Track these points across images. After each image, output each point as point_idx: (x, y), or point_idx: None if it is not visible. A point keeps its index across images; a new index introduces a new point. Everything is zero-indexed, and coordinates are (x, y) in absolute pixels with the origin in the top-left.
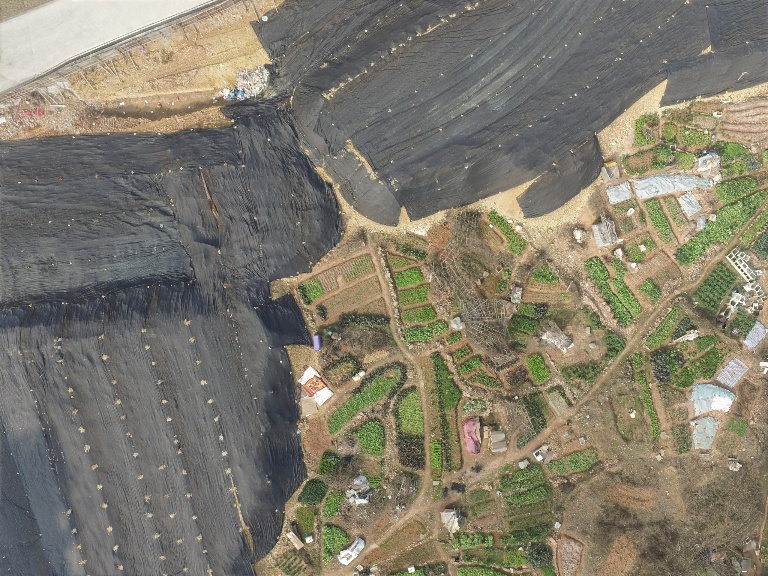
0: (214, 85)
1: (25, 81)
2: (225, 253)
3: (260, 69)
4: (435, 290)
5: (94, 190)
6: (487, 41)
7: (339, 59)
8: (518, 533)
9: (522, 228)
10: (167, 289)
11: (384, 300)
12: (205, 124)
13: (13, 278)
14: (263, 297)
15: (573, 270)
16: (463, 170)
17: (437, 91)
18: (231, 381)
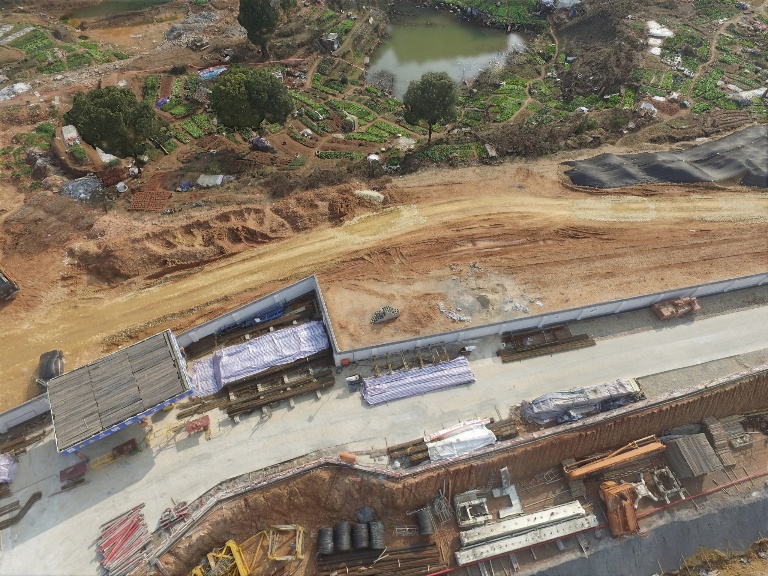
0: None
1: None
2: None
3: None
4: None
5: None
6: None
7: None
8: (709, 3)
9: None
10: None
11: None
12: None
13: None
14: None
15: None
16: None
17: None
18: None
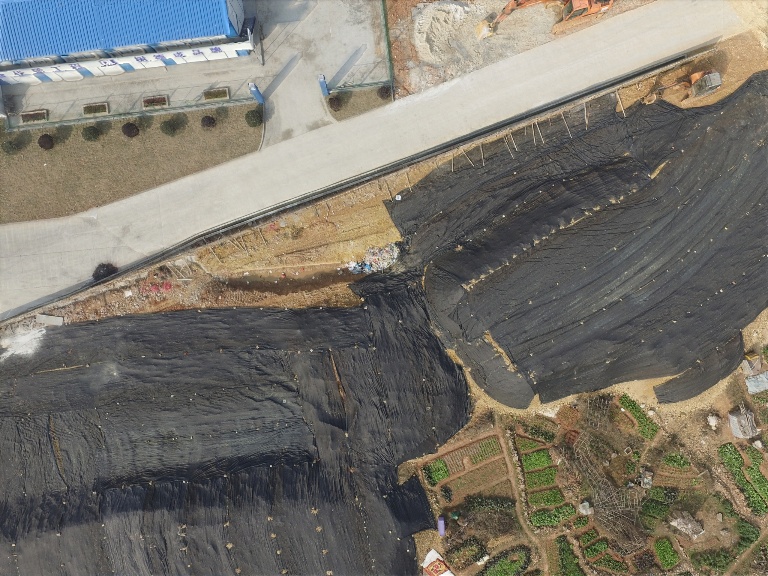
0: (342, 259)
1: (153, 254)
2: (352, 436)
3: (390, 246)
4: (563, 473)
5: (218, 364)
6: (631, 234)
7: (474, 242)
8: None
9: (654, 412)
10: (291, 470)
11: (510, 482)
12: (334, 301)
13: (132, 452)
14: (391, 483)
15: (705, 455)
16: (604, 364)
17: (579, 284)
18: (358, 572)
